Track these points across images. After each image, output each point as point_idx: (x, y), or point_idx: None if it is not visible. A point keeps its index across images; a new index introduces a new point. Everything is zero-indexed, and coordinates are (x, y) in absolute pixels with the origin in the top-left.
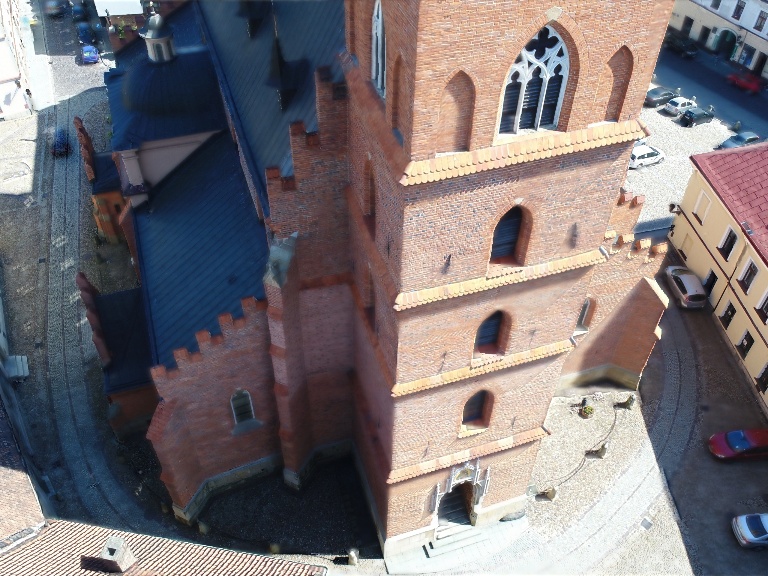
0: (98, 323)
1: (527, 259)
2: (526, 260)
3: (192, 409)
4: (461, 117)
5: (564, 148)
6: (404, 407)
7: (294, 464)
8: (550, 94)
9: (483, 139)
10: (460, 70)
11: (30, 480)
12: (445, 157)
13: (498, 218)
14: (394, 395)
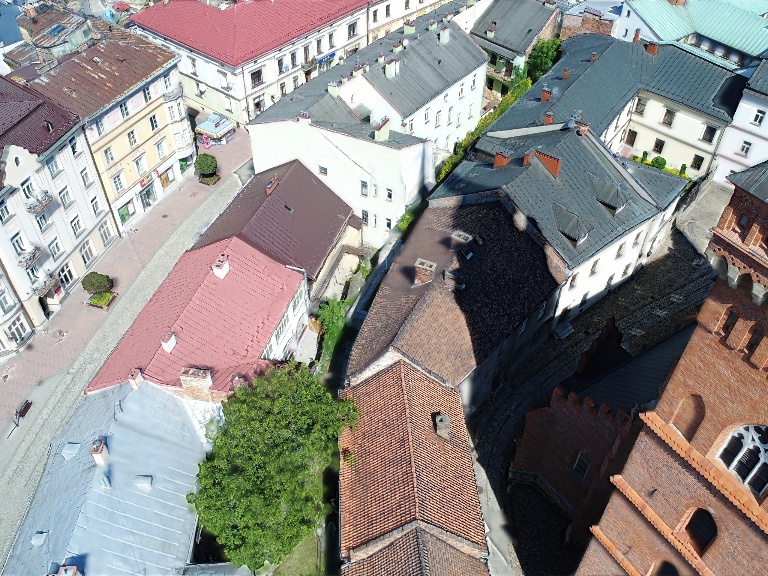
0: (595, 349)
1: (705, 557)
2: (704, 556)
3: (558, 429)
4: (695, 421)
5: (750, 512)
6: (597, 547)
7: (574, 526)
8: (765, 473)
9: (701, 446)
10: (700, 395)
11: (475, 368)
12: (674, 430)
13: (695, 505)
14: (591, 529)
